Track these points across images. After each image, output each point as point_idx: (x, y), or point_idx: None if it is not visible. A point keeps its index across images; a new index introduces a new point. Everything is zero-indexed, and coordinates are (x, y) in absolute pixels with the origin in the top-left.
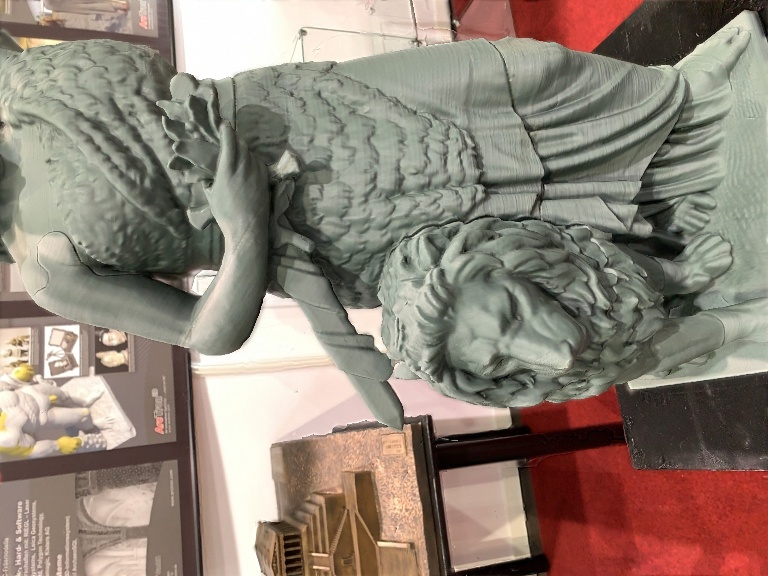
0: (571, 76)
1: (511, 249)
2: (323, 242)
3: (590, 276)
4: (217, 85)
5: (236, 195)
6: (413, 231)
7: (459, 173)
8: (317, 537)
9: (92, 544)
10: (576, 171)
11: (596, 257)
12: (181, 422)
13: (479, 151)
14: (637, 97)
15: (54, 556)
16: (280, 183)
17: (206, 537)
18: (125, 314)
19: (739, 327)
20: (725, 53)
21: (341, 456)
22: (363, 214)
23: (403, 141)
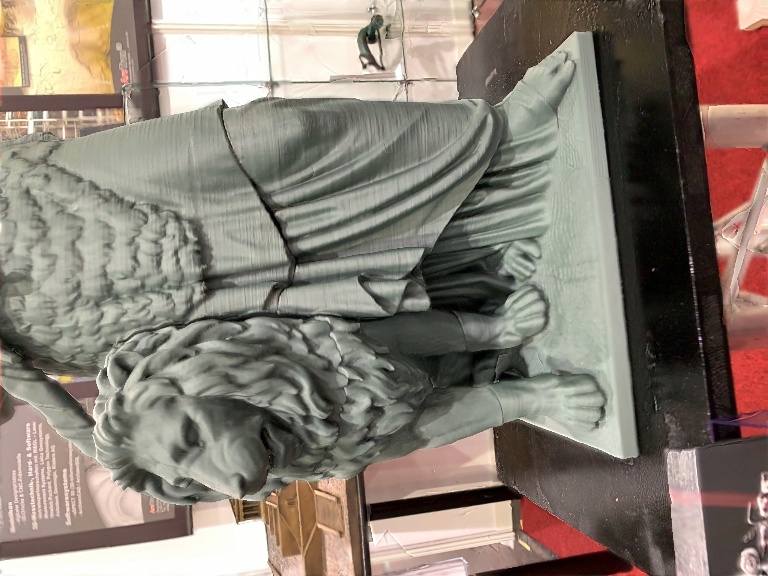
0: (326, 144)
1: (197, 373)
2: (38, 347)
3: (303, 387)
4: None
5: None
6: (127, 335)
7: (175, 273)
8: None
9: (92, 461)
10: (346, 242)
11: (330, 355)
12: None
13: (208, 242)
14: (427, 150)
15: (60, 470)
16: None
17: None
18: None
19: (519, 408)
20: (547, 86)
21: None
22: (70, 322)
23: (110, 244)
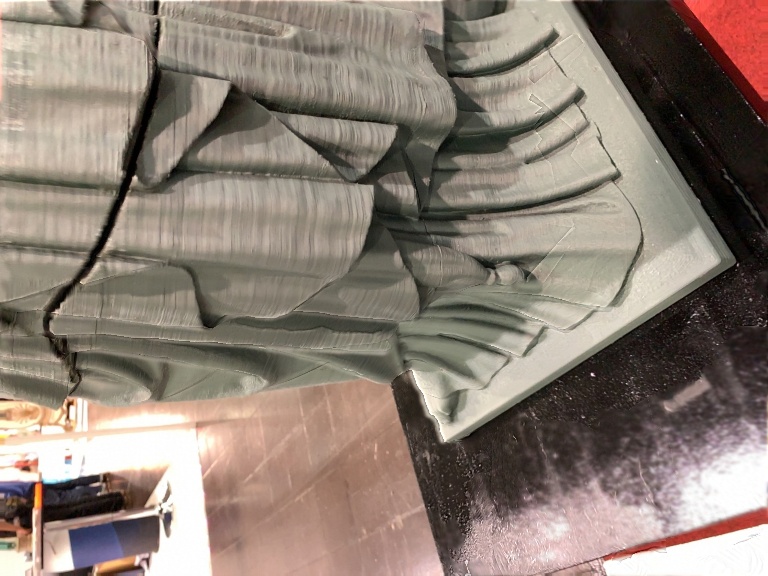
0: None
1: None
2: None
3: None
4: None
5: None
6: None
7: None
8: None
9: None
10: None
11: None
12: None
13: None
14: None
15: None
16: None
17: None
18: None
19: None
20: None
21: None
22: None
23: None
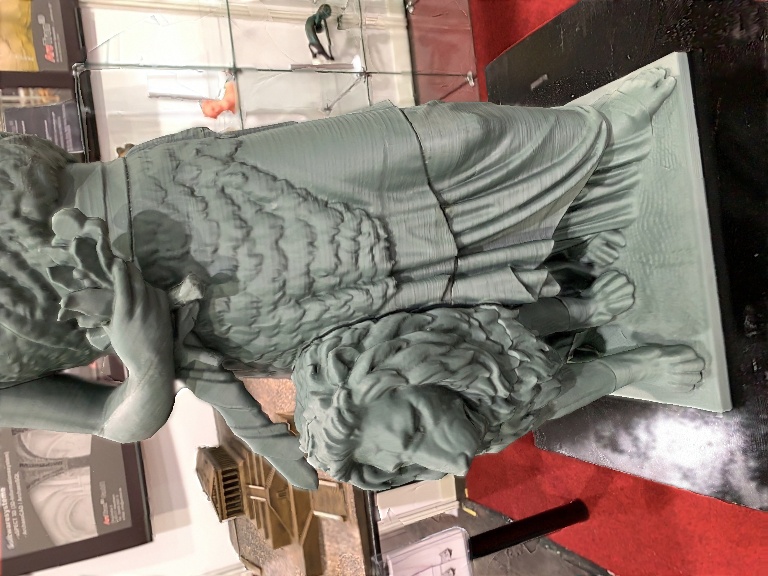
0: (490, 146)
1: (417, 363)
2: (233, 348)
3: (493, 370)
4: (108, 180)
5: (136, 338)
6: (324, 331)
7: (370, 270)
8: (253, 471)
9: (35, 476)
10: None
11: (501, 340)
12: (114, 356)
13: (392, 238)
14: (557, 152)
15: None
16: (183, 307)
17: (148, 459)
18: (32, 421)
19: (629, 377)
20: (650, 98)
21: (274, 399)
22: (272, 322)
23: (313, 242)
